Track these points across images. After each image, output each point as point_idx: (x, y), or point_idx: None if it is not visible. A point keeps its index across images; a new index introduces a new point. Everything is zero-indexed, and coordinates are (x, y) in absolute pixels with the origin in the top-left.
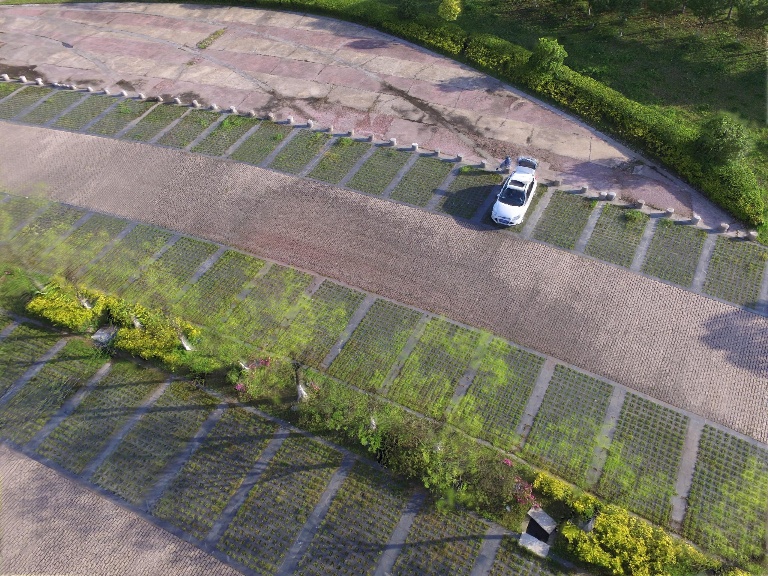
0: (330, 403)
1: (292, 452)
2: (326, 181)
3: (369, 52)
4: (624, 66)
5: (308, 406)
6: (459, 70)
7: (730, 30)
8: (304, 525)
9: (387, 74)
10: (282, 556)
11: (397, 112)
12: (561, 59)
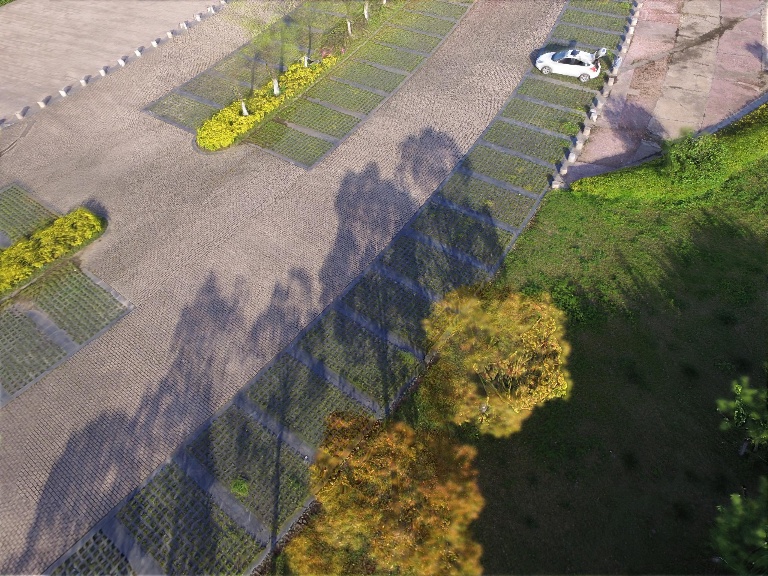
0: (379, 7)
1: (356, 5)
2: (570, 2)
3: None
4: None
5: (377, 1)
6: None
7: None
8: (322, 10)
9: (762, 19)
10: (310, 6)
11: (688, 25)
12: None
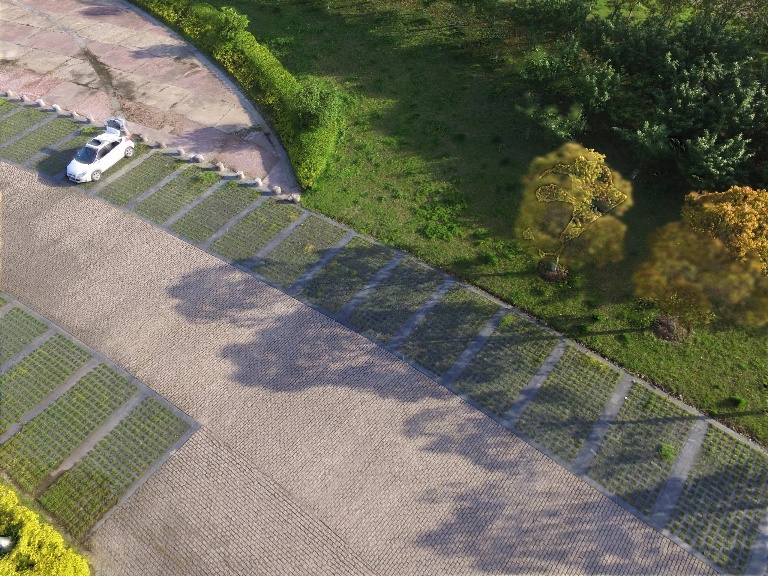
0: None
1: None
2: None
3: (94, 18)
4: (311, 38)
5: None
6: (166, 38)
7: (430, 6)
8: None
9: (94, 40)
10: None
11: (71, 76)
12: (239, 28)
